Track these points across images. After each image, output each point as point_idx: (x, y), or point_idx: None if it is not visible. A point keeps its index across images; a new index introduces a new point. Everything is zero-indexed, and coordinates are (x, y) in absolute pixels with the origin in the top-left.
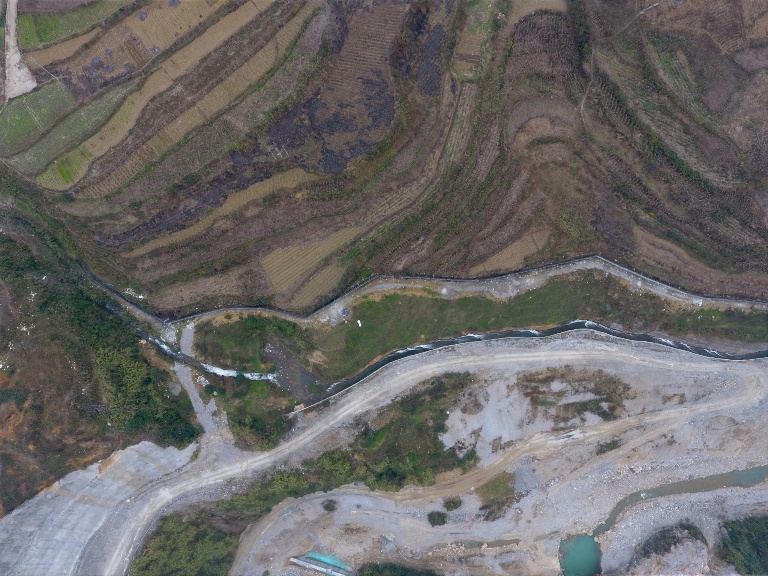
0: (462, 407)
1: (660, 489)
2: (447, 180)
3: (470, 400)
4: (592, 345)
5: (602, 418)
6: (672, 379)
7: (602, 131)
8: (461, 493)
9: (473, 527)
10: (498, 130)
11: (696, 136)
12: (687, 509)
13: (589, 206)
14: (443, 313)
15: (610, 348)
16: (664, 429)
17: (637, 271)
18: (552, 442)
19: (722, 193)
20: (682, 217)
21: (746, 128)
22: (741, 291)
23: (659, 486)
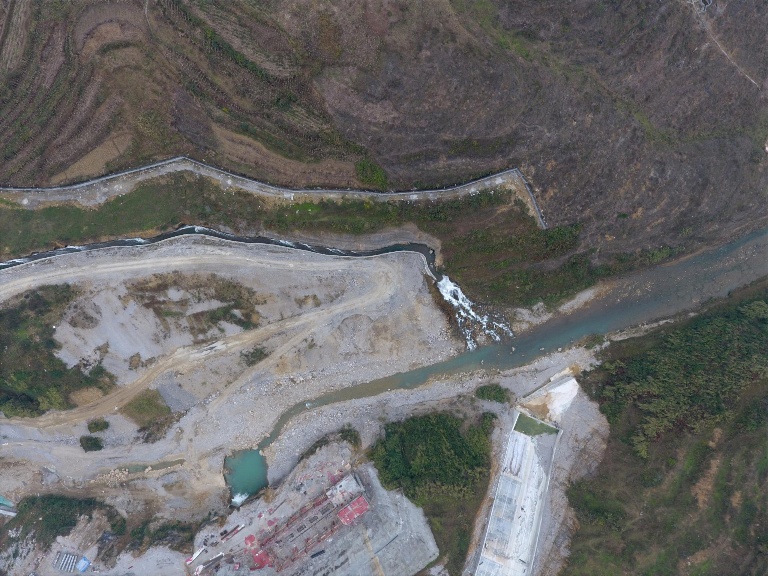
0: (69, 320)
1: (325, 398)
2: (1, 86)
3: (76, 313)
4: (203, 250)
5: (242, 327)
6: (294, 279)
7: (167, 31)
8: (105, 414)
9: (132, 450)
10: (62, 36)
11: (249, 27)
12: (349, 414)
13: (167, 107)
14: (28, 224)
15: (224, 252)
16: (305, 333)
17: (224, 169)
18: (195, 355)
19: (280, 81)
20: (249, 109)
21: (294, 15)
22: (327, 181)
23: (323, 395)
